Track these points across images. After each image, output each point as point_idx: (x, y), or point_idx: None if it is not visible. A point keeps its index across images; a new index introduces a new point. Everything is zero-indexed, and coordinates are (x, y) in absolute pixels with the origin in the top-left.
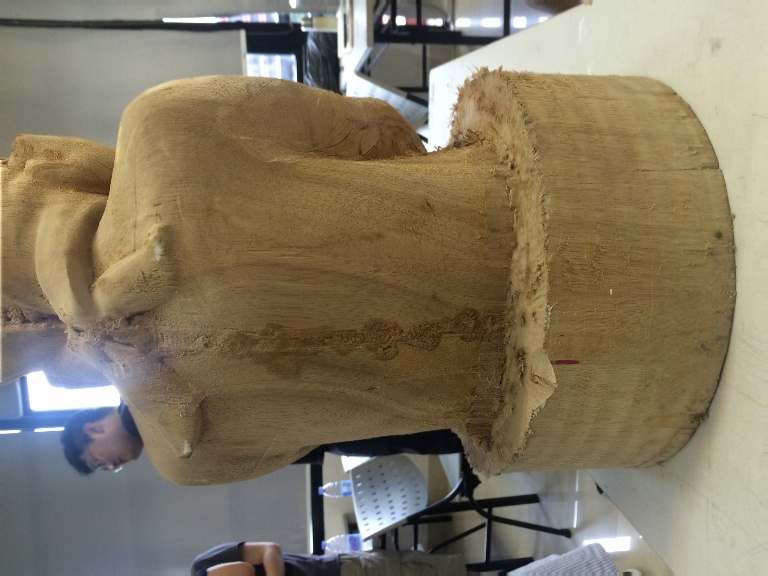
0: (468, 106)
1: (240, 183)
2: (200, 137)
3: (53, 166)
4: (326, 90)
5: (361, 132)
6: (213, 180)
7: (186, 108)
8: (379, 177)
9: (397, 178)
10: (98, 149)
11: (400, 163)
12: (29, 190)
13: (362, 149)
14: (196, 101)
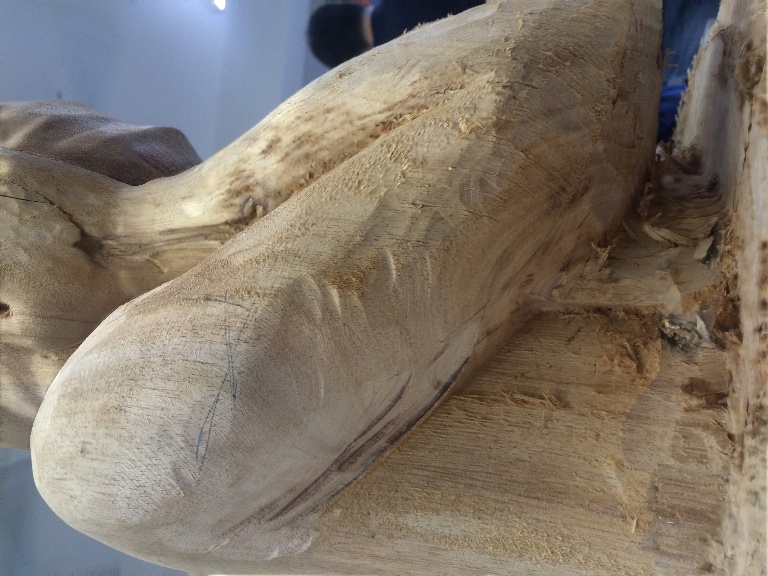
0: None
1: (242, 574)
2: (156, 556)
3: (6, 338)
4: (338, 294)
5: (432, 366)
6: (206, 572)
7: (110, 534)
8: (448, 568)
9: (480, 570)
10: (33, 272)
11: (498, 498)
12: (9, 365)
13: (440, 377)
14: (116, 527)
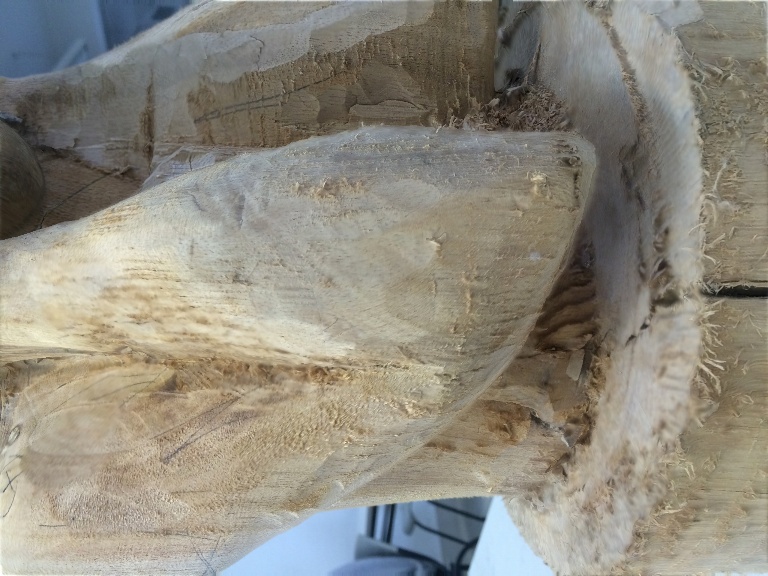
0: (653, 409)
1: None
2: None
3: None
4: (297, 514)
5: None
6: None
7: None
8: None
9: None
10: None
11: (398, 487)
12: None
13: None
14: None
